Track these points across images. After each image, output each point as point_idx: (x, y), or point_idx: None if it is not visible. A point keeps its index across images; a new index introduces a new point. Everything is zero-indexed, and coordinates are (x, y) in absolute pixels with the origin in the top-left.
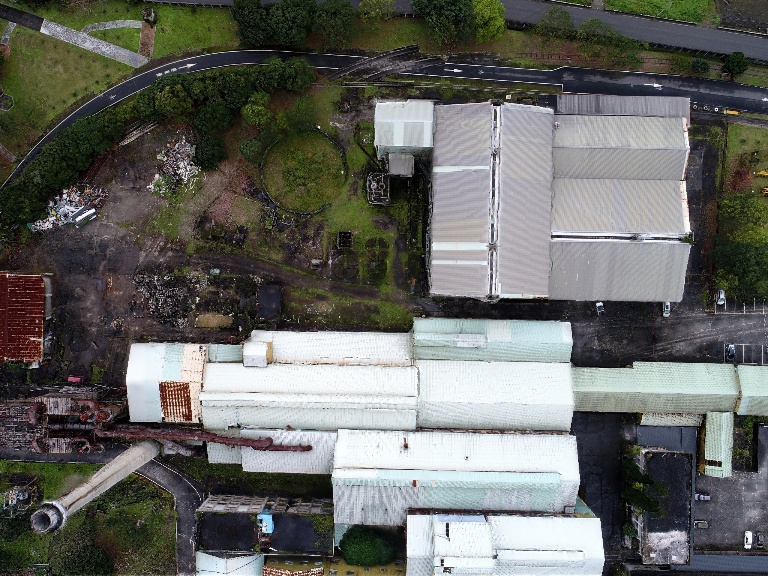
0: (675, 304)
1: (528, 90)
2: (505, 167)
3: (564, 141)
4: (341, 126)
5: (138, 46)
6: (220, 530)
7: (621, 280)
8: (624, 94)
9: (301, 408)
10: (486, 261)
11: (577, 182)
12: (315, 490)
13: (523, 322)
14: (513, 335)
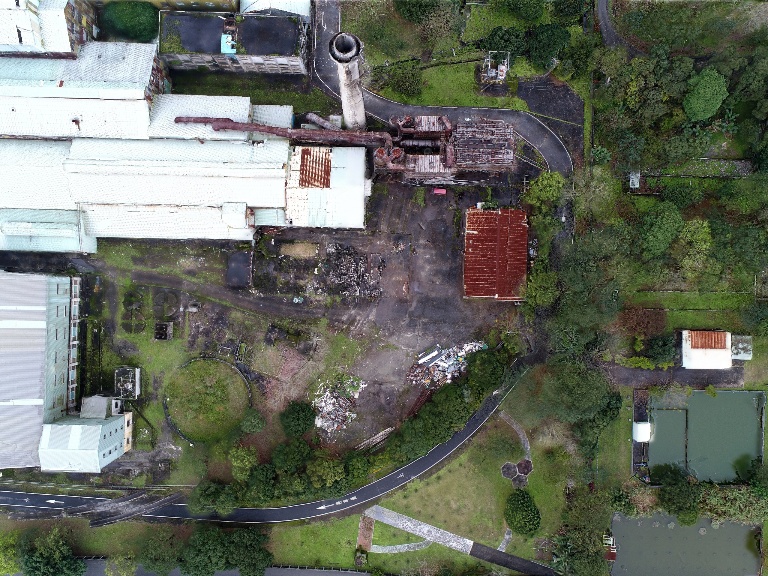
0: None
1: None
2: None
3: None
4: (170, 446)
5: (375, 527)
6: (276, 38)
7: None
8: None
9: None
10: None
11: None
12: (198, 78)
13: None
14: None
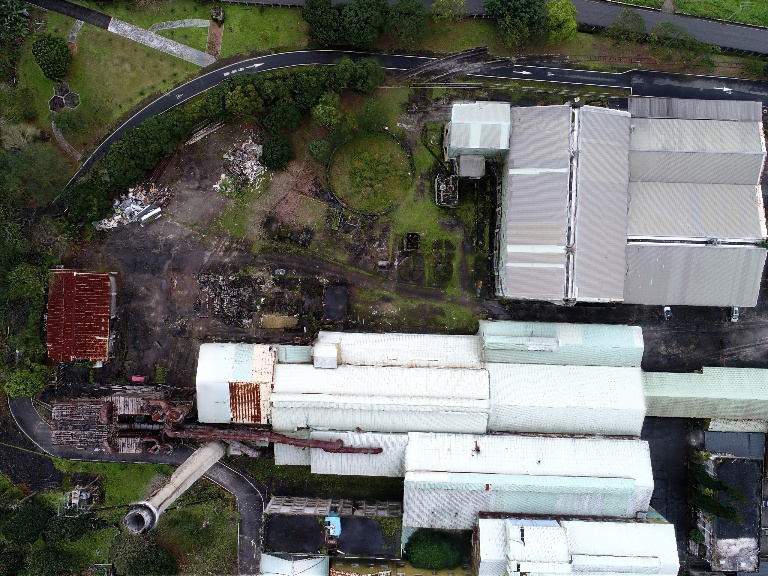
0: (743, 309)
1: (597, 93)
2: (583, 170)
3: (640, 144)
4: (408, 127)
5: (206, 45)
6: (287, 532)
7: (696, 285)
8: (694, 98)
9: (372, 410)
10: (563, 264)
11: (652, 186)
12: (378, 493)
13: (593, 326)
14: (584, 339)
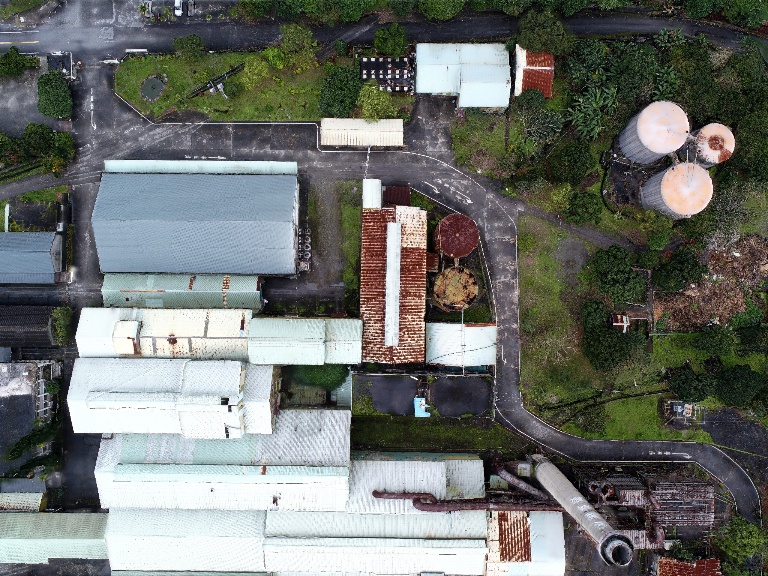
0: None
1: None
2: None
3: None
4: None
5: None
6: (469, 398)
7: None
8: None
9: (384, 535)
10: None
11: None
12: None
13: None
14: None
